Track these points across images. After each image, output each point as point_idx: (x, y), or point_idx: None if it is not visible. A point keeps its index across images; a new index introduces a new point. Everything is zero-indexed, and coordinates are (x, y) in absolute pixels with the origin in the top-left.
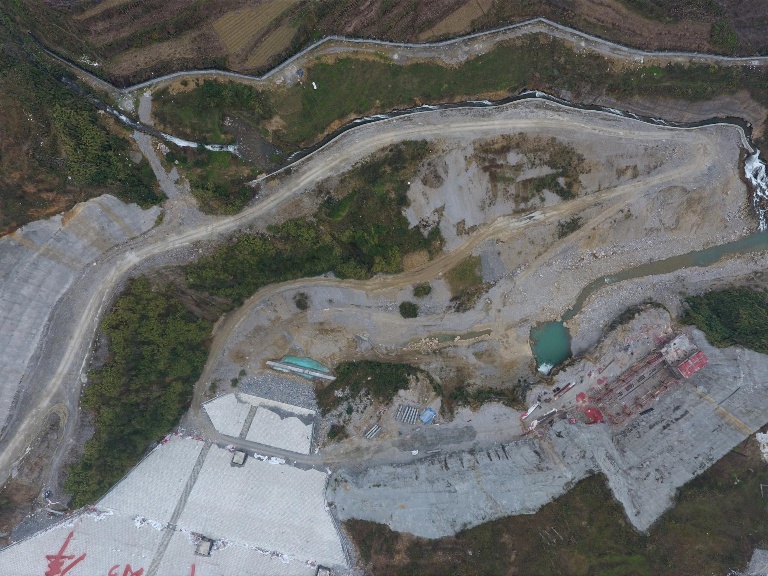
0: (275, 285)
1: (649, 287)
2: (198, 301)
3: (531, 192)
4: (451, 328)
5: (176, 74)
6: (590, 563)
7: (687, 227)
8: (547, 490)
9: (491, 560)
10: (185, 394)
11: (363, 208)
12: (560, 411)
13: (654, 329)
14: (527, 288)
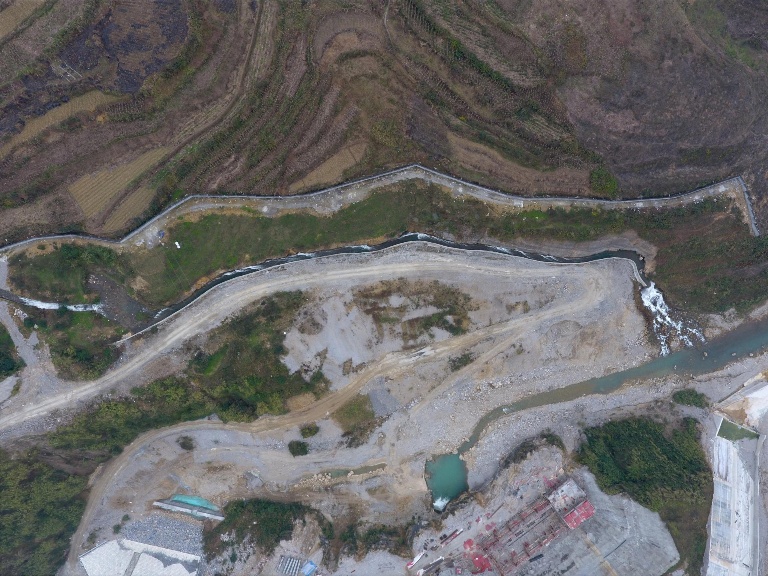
0: (156, 430)
1: (547, 417)
2: (68, 458)
3: (419, 330)
4: (343, 464)
5: (32, 239)
6: None
7: (585, 357)
8: None
9: None
10: (59, 550)
11: (237, 361)
12: (447, 559)
13: (544, 472)
14: (422, 421)
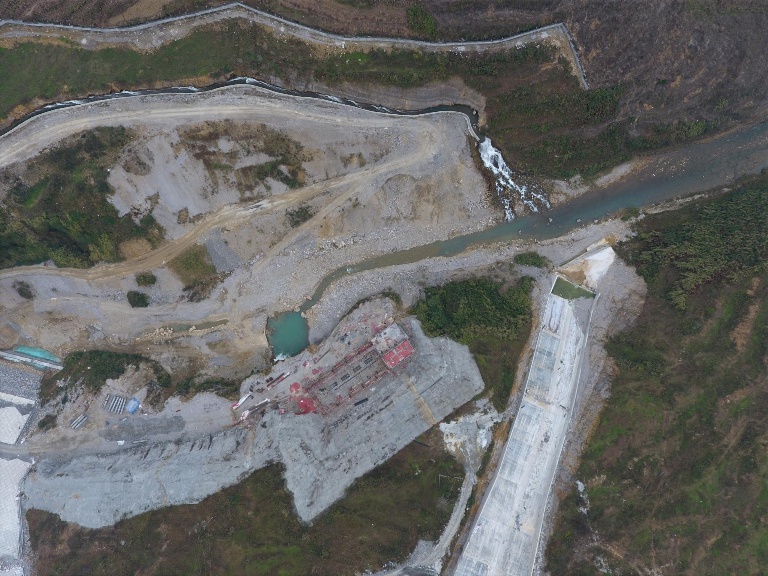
0: None
1: (389, 277)
2: None
3: (254, 180)
4: (184, 318)
5: None
6: (246, 553)
7: (426, 216)
8: (220, 480)
9: (140, 550)
10: None
11: (59, 195)
12: (273, 401)
13: (372, 319)
14: (264, 278)
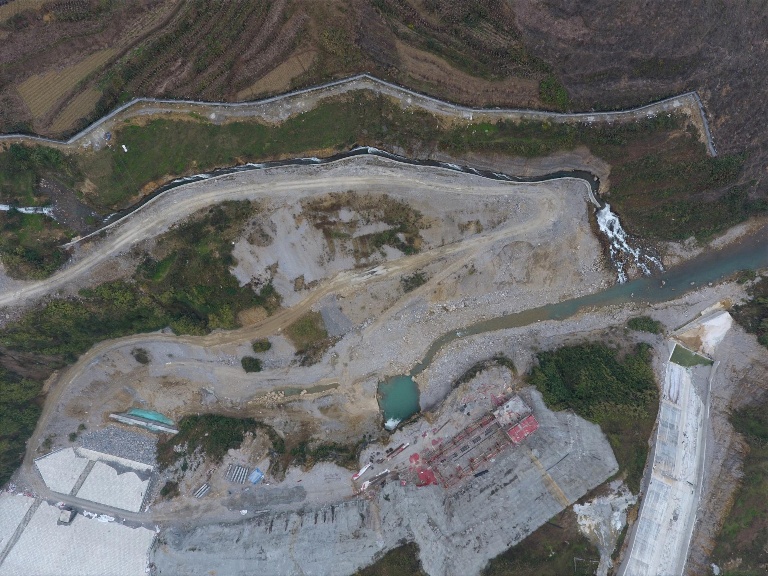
0: (111, 341)
1: (501, 341)
2: (21, 361)
3: (370, 247)
4: (296, 382)
5: None
6: None
7: (539, 281)
8: (355, 560)
9: None
10: (14, 451)
11: (185, 269)
12: (393, 472)
13: (492, 389)
14: (375, 342)
